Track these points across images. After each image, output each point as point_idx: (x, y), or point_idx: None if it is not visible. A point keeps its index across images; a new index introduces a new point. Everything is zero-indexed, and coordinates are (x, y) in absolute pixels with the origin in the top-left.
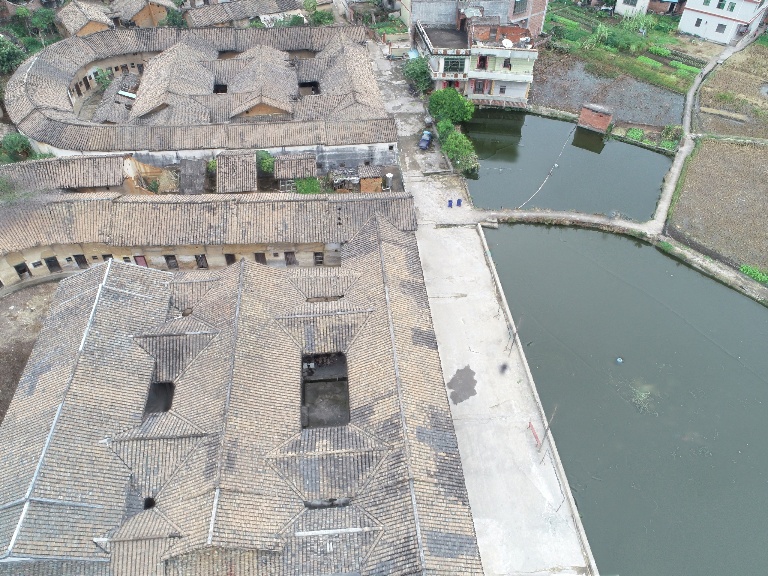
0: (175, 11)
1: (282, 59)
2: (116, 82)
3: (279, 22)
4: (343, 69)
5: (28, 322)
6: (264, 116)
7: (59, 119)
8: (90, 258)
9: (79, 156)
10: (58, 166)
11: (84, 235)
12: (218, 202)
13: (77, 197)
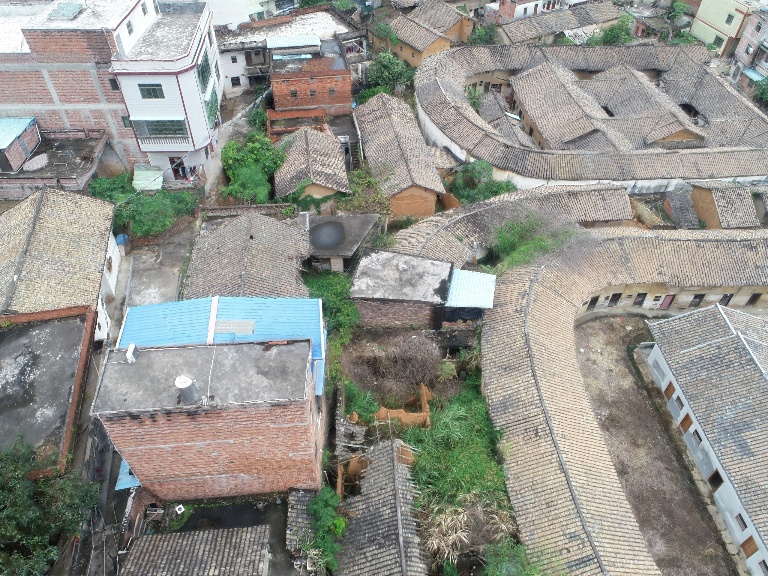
0: (480, 25)
1: (647, 80)
2: (489, 102)
3: (594, 38)
4: (723, 92)
5: (611, 367)
6: (679, 142)
7: (512, 145)
8: (625, 297)
9: (564, 186)
10: (569, 198)
11: (644, 275)
12: (757, 240)
13: (613, 233)
